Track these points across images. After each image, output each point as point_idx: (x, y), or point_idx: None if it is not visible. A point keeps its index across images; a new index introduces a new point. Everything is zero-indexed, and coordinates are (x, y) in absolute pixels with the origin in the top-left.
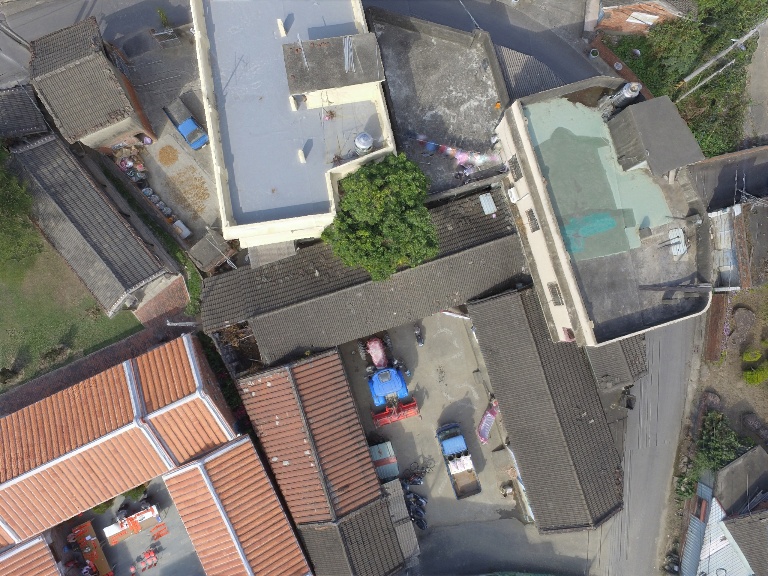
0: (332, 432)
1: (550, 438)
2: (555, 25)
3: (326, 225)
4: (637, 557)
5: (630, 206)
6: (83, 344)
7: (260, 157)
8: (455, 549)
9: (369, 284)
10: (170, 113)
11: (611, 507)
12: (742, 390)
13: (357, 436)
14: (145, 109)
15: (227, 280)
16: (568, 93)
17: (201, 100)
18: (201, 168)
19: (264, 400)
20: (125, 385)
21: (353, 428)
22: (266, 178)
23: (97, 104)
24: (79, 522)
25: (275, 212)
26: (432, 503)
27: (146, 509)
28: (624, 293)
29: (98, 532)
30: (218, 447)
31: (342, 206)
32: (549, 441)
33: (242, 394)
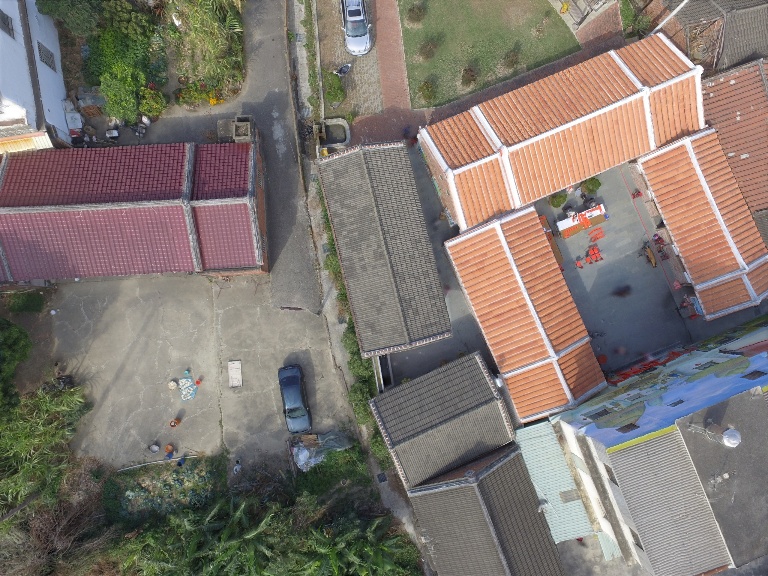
0: None
1: None
2: None
3: None
4: None
5: None
6: (526, 60)
7: None
8: None
9: None
10: None
11: None
12: None
13: None
14: None
15: None
16: None
17: None
18: None
19: (723, 99)
20: (618, 67)
21: None
22: None
23: None
24: None
25: None
26: None
27: (595, 207)
28: None
29: None
30: None
31: None
32: None
33: None
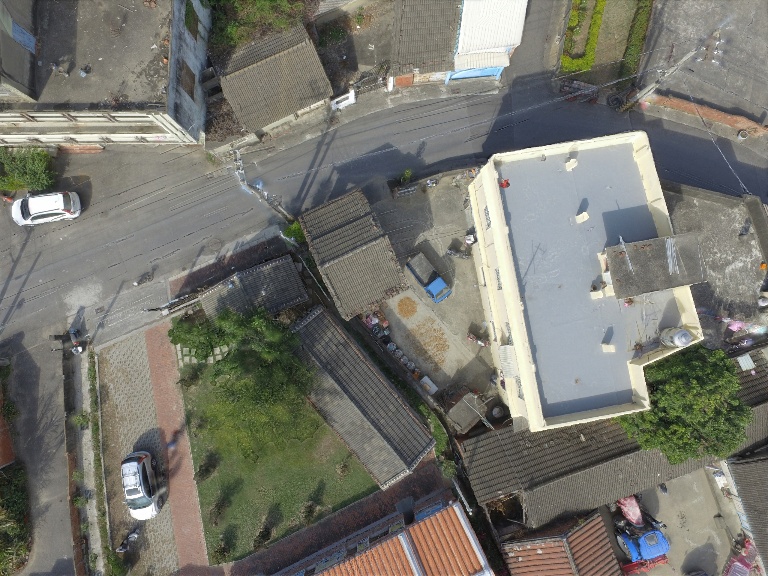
0: None
1: None
2: None
3: None
4: None
5: None
6: (331, 500)
7: (562, 347)
8: None
9: (640, 451)
10: (412, 267)
11: None
12: None
13: None
14: None
15: (487, 443)
16: None
17: (436, 250)
18: (439, 319)
19: (532, 566)
20: (405, 560)
21: None
22: (569, 368)
23: (375, 283)
24: None
25: (580, 403)
26: None
27: None
28: None
29: None
30: None
31: (651, 398)
32: None
33: (507, 558)
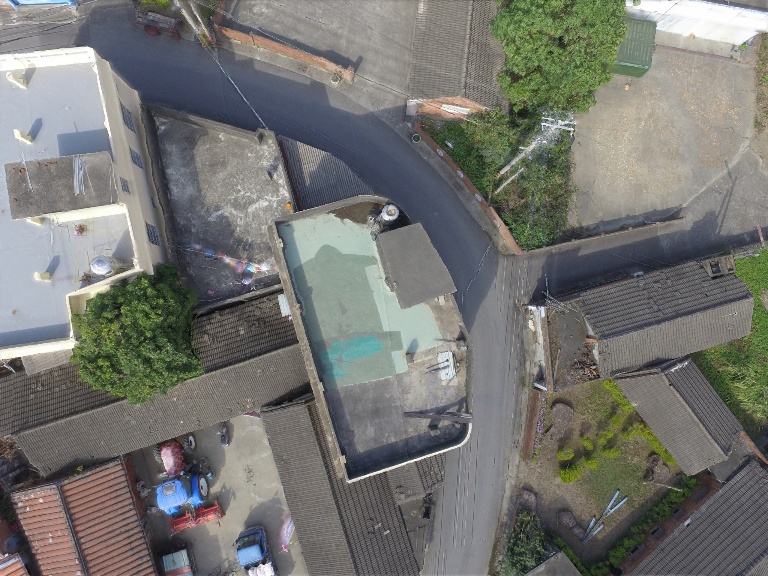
0: (109, 550)
1: (338, 553)
2: (378, 108)
3: None
4: None
5: (398, 328)
6: None
7: (0, 275)
8: None
9: None
10: None
11: None
12: (560, 486)
13: (140, 551)
14: None
15: (2, 386)
16: (335, 209)
17: None
18: None
19: (38, 515)
20: None
21: (135, 543)
22: (6, 298)
23: None
24: None
25: (16, 335)
26: None
27: None
28: (388, 420)
29: None
30: None
31: None
32: (337, 556)
33: (17, 508)
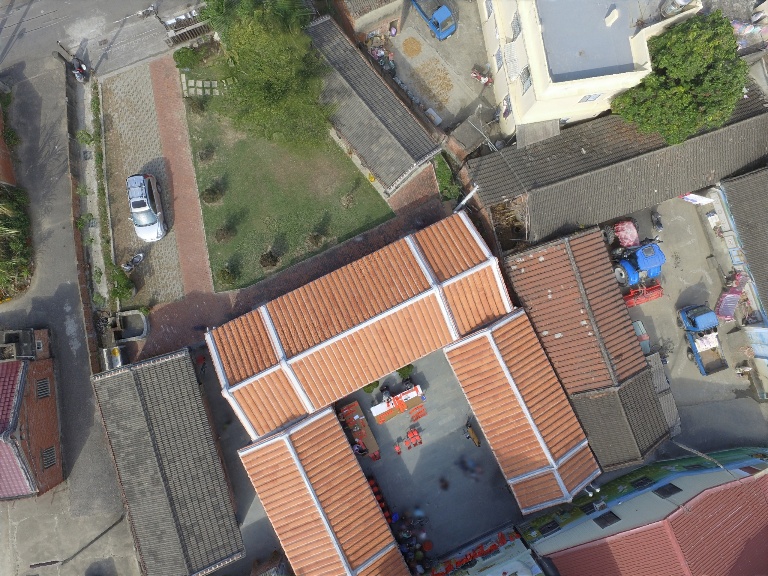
0: (603, 304)
1: None
2: None
3: (627, 89)
4: None
5: None
6: (337, 232)
7: (567, 21)
8: (696, 427)
9: (639, 159)
10: (417, 3)
11: None
12: None
13: (622, 310)
14: None
15: (491, 161)
16: None
17: None
18: (443, 59)
19: (534, 275)
20: (412, 257)
21: (619, 302)
22: (573, 41)
23: None
24: (346, 402)
25: (583, 74)
26: (672, 384)
27: (411, 389)
28: None
29: (364, 412)
30: (496, 320)
31: (652, 66)
32: None
33: (510, 271)
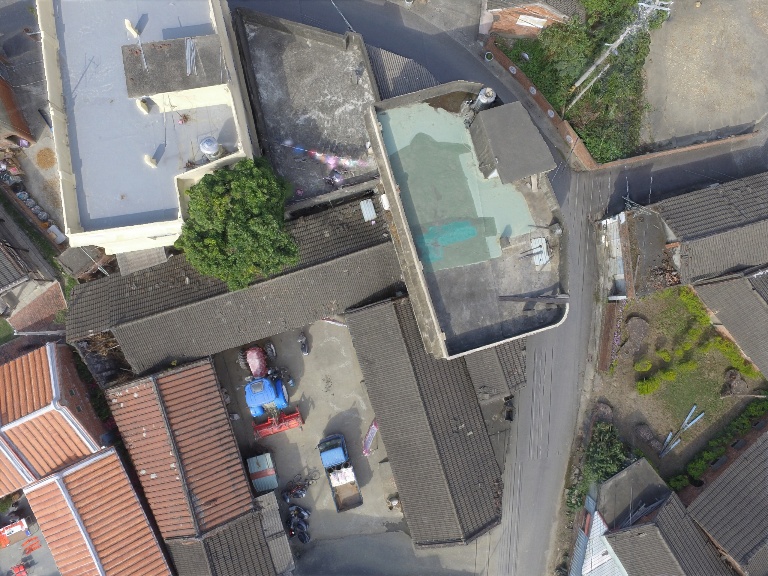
0: (201, 444)
1: (424, 451)
2: (450, 27)
3: (180, 232)
4: (526, 571)
5: (492, 214)
6: None
7: (110, 162)
8: (339, 563)
9: (239, 292)
10: (46, 115)
11: (487, 521)
12: (635, 401)
13: (229, 448)
14: (24, 110)
15: (97, 287)
16: (429, 98)
17: None
18: None
19: (132, 411)
20: None
21: (225, 440)
22: (115, 184)
23: None
24: None
25: (124, 219)
26: (316, 516)
27: (15, 522)
28: (483, 304)
29: None
30: (82, 460)
31: None
32: (423, 454)
33: (111, 405)
